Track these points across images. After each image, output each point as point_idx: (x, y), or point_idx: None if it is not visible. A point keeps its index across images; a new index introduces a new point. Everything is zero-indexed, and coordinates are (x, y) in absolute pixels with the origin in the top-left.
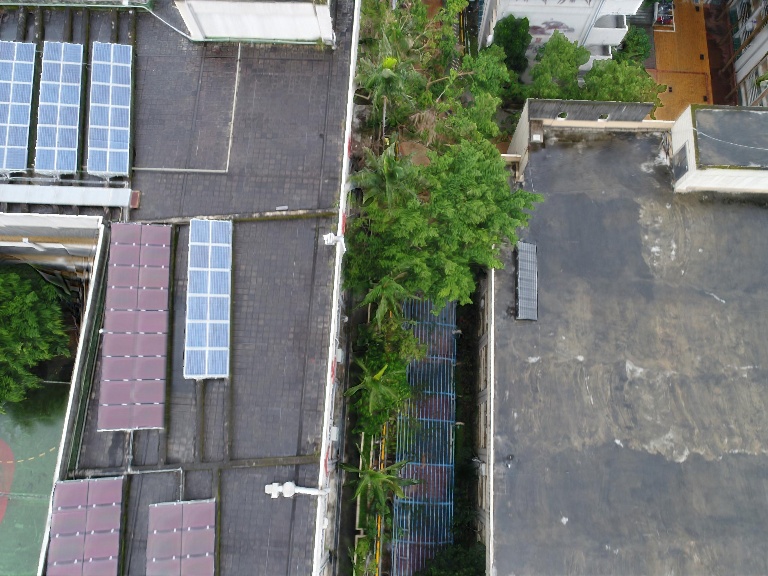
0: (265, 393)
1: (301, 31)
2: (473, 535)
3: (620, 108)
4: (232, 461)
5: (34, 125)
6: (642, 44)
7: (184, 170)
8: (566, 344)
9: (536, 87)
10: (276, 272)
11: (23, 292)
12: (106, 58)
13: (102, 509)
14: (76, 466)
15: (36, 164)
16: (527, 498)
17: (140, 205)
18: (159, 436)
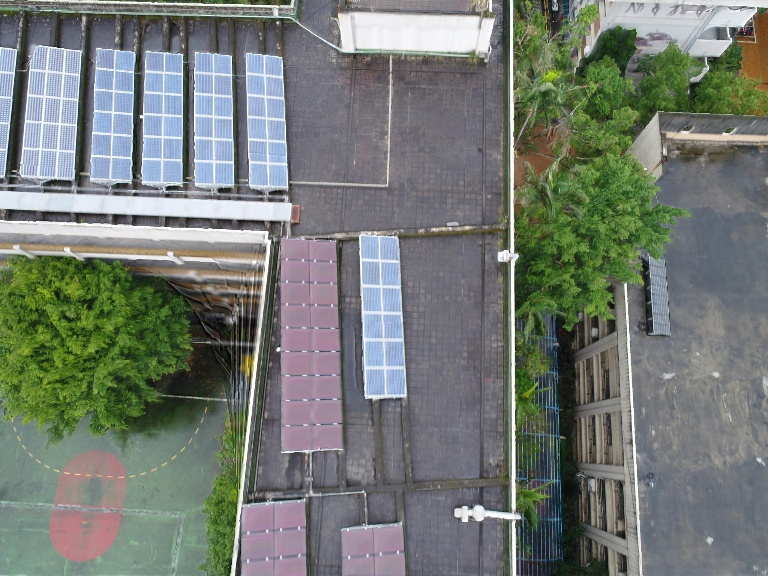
0: (443, 413)
1: (456, 44)
2: (574, 551)
3: (750, 122)
4: (416, 483)
5: (186, 137)
6: (735, 55)
7: (343, 184)
8: (701, 360)
9: (650, 99)
10: (445, 289)
11: (156, 306)
12: (259, 70)
13: (288, 533)
14: (254, 488)
15: (196, 178)
16: (670, 517)
17: (300, 220)
18: (339, 457)
